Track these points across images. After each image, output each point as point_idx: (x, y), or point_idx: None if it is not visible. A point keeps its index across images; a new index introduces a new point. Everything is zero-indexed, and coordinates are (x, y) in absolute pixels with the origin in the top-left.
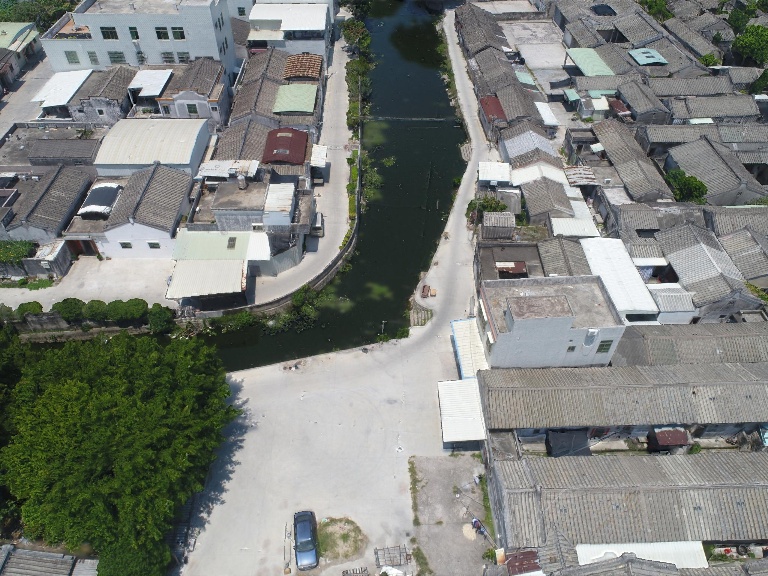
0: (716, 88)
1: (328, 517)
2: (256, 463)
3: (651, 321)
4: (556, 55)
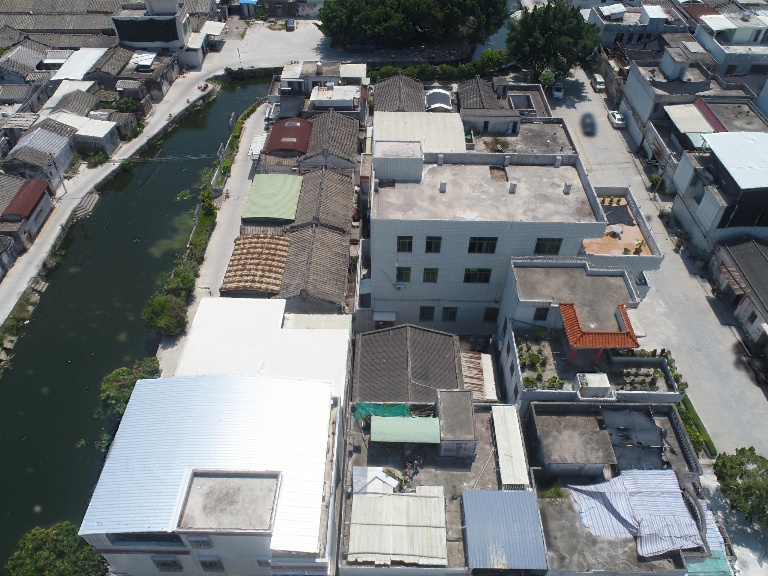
0: None
1: None
2: None
3: None
4: None
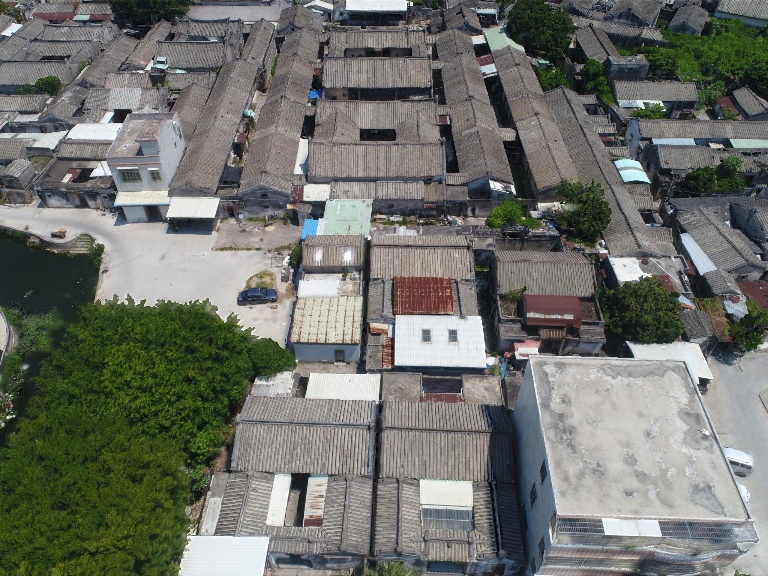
0: None
1: (244, 289)
2: None
3: None
4: None
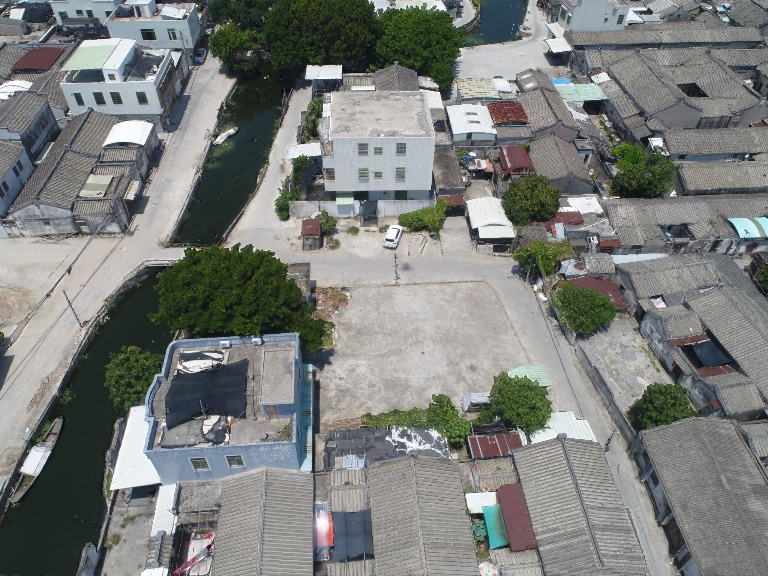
0: None
1: None
2: (468, 70)
3: None
4: None
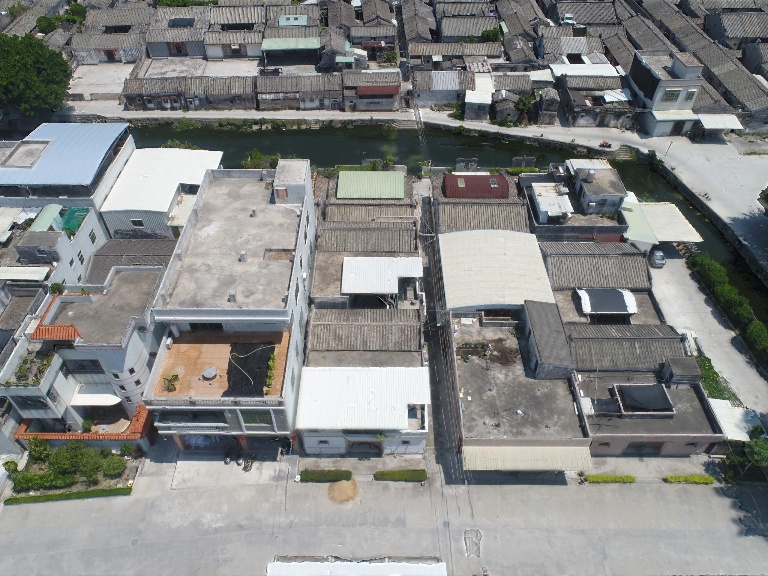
0: (350, 9)
1: None
2: None
3: (616, 68)
4: (235, 66)
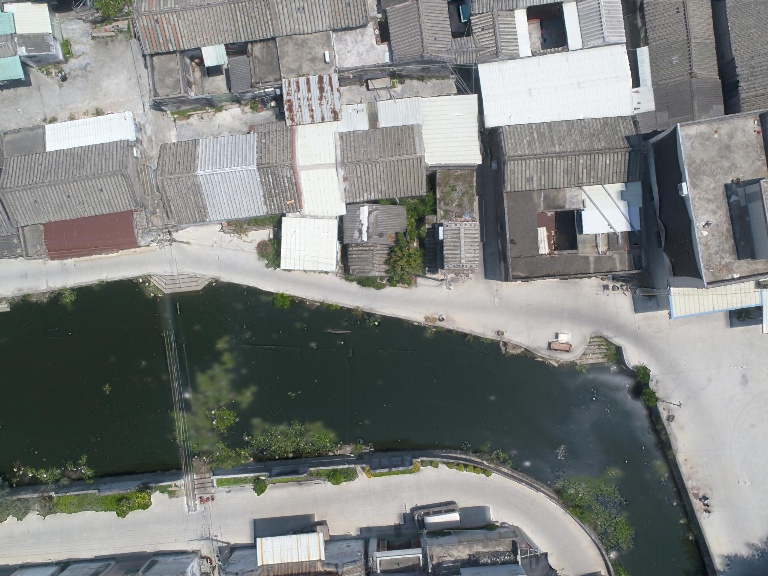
0: None
1: None
2: None
3: (637, 58)
4: None
